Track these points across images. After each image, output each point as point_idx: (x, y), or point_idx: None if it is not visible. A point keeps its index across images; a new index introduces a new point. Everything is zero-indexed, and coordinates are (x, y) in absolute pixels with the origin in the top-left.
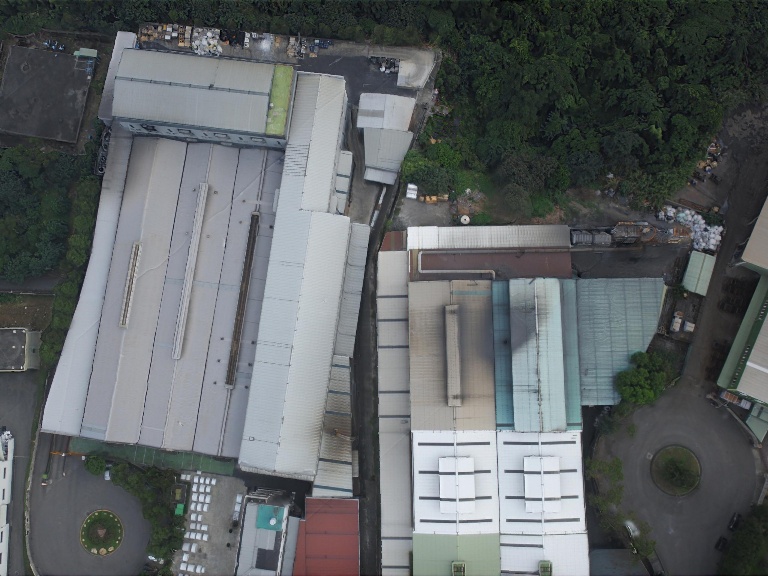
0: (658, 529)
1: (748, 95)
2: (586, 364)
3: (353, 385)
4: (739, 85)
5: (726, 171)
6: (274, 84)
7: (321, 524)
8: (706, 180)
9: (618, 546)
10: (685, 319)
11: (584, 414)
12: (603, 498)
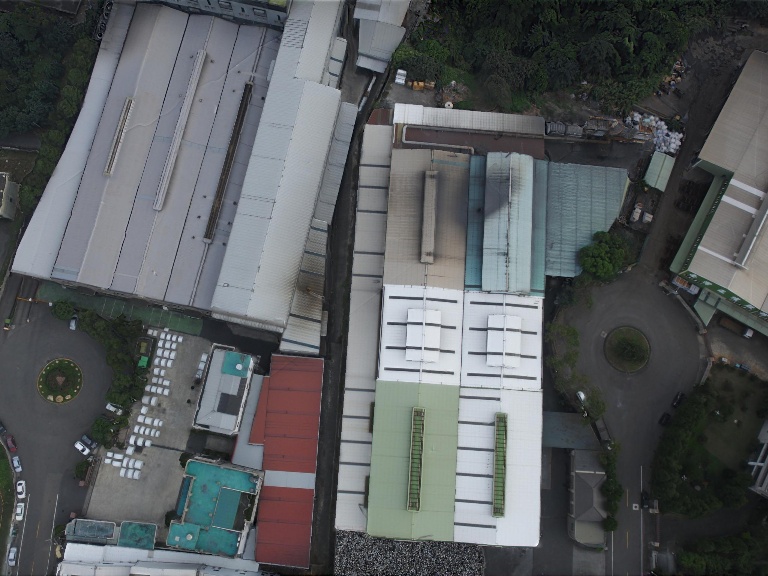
0: (608, 398)
1: (711, 23)
2: (552, 238)
3: (328, 252)
4: (704, 14)
5: (688, 87)
6: None
7: (285, 381)
8: (670, 93)
9: (570, 410)
10: (644, 210)
11: (547, 283)
12: (560, 359)
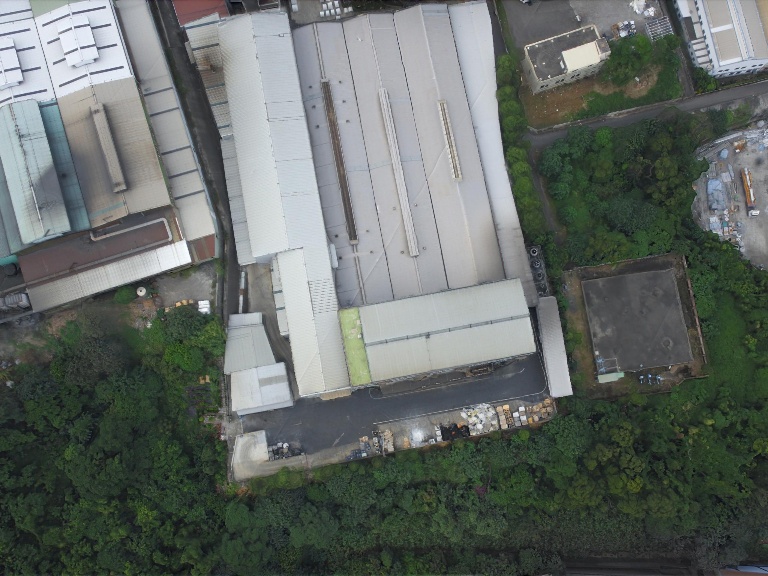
0: None
1: None
2: None
3: None
4: None
5: None
6: (366, 361)
7: None
8: None
9: None
10: None
11: None
12: None
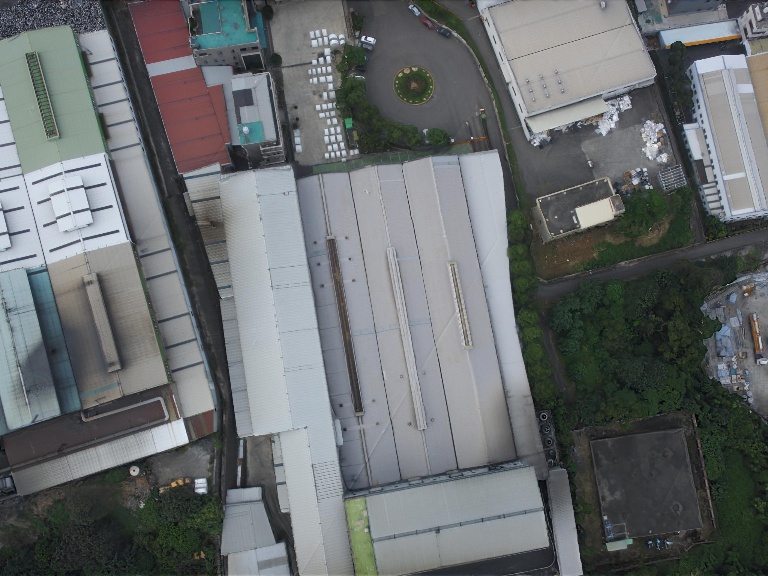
0: None
1: None
2: None
3: None
4: None
5: None
6: (373, 556)
7: (209, 145)
8: None
9: None
10: None
11: None
12: None
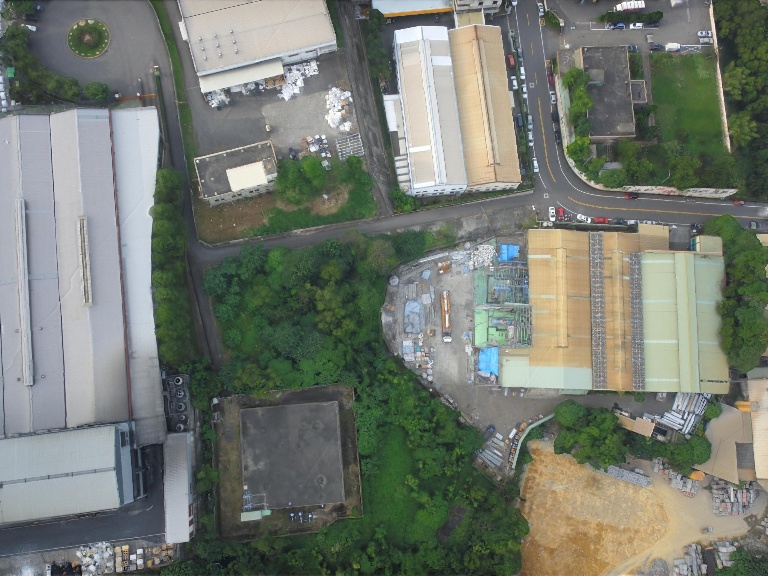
0: None
1: None
2: None
3: None
4: None
5: None
6: None
7: None
8: None
9: None
10: None
11: None
12: None
